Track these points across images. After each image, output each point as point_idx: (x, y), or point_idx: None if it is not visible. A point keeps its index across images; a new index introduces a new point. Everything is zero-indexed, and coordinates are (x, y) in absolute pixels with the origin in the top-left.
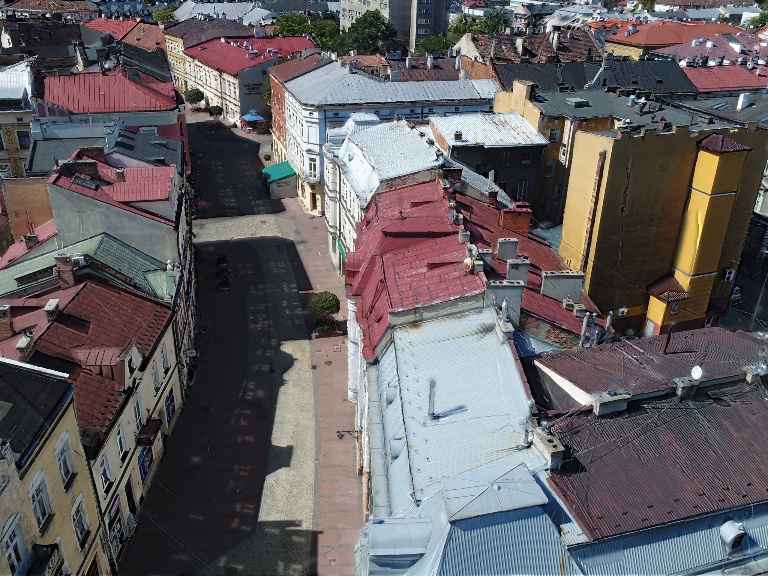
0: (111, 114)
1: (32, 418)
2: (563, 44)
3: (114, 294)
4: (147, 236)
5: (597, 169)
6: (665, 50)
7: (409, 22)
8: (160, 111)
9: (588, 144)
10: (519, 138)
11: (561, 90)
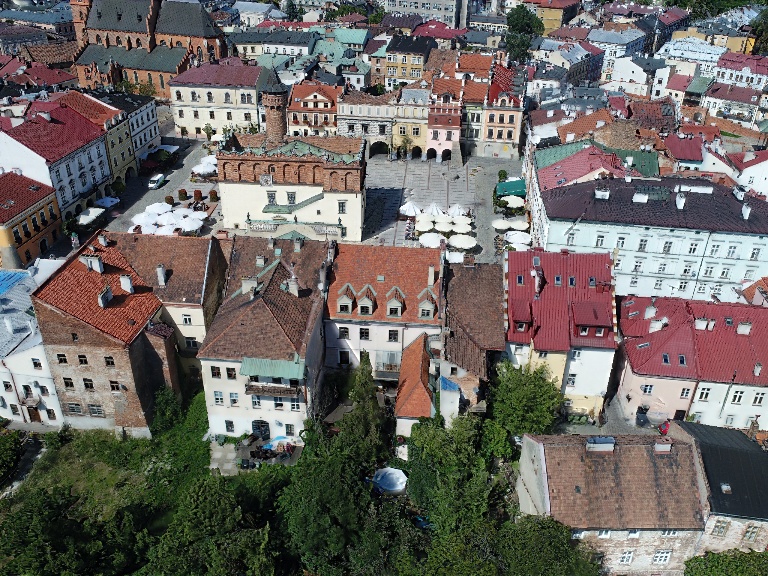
0: None
1: None
2: None
3: None
4: None
5: (742, 45)
6: None
7: (460, 6)
8: None
9: (735, 40)
10: None
11: None
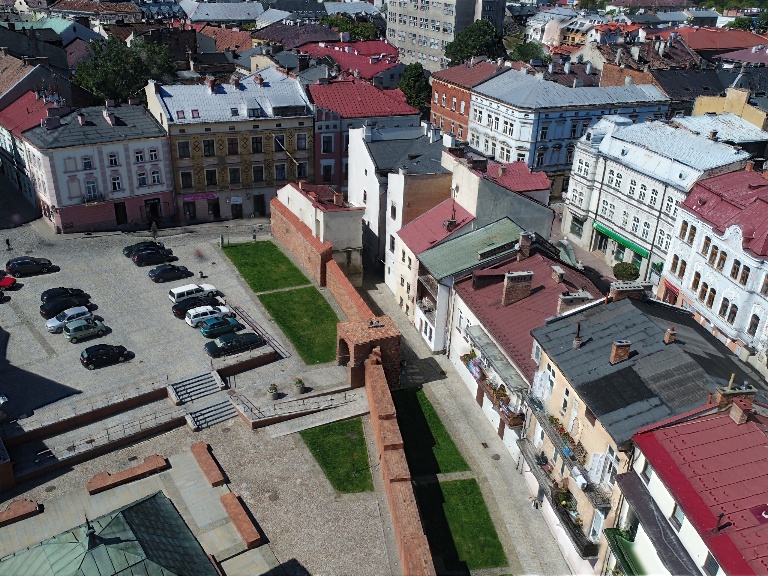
0: (373, 118)
1: (711, 337)
2: (666, 52)
3: (556, 263)
4: (534, 219)
5: None
6: (727, 55)
7: None
8: (411, 115)
9: None
10: (752, 135)
11: (756, 95)
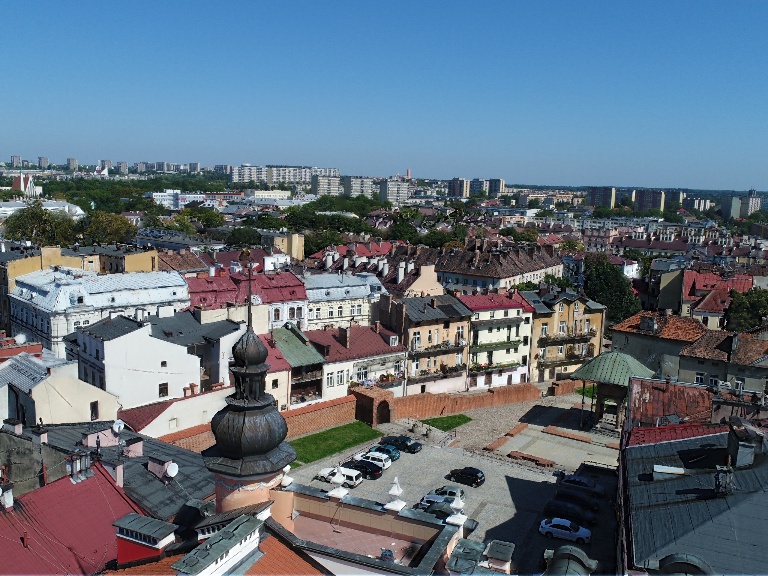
0: None
1: None
2: None
3: None
4: None
5: None
6: None
7: None
8: None
9: None
10: None
11: (26, 252)
